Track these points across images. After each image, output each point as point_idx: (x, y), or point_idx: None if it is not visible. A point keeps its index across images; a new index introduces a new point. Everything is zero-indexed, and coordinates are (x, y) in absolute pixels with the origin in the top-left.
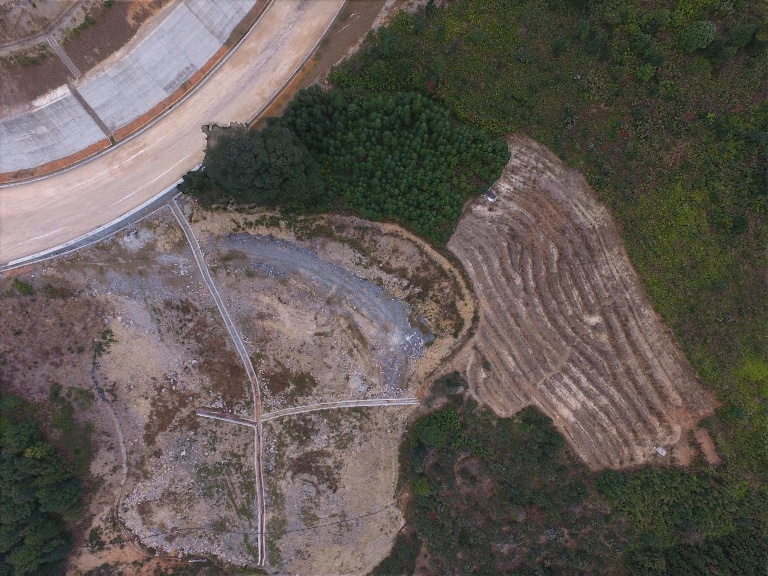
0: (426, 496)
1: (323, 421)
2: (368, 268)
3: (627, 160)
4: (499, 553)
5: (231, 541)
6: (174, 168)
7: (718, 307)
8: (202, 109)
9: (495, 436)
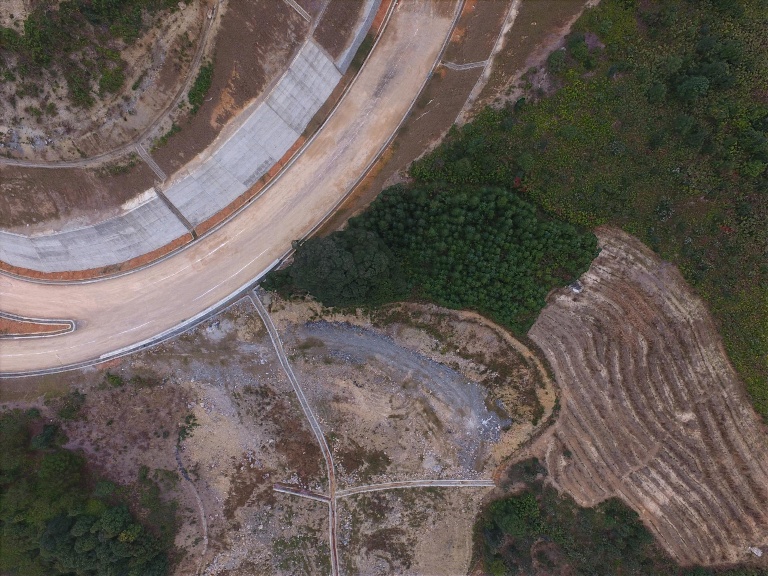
0: None
1: (397, 500)
2: (445, 353)
3: (728, 254)
4: None
5: None
6: (254, 261)
7: None
8: (280, 201)
9: (576, 525)
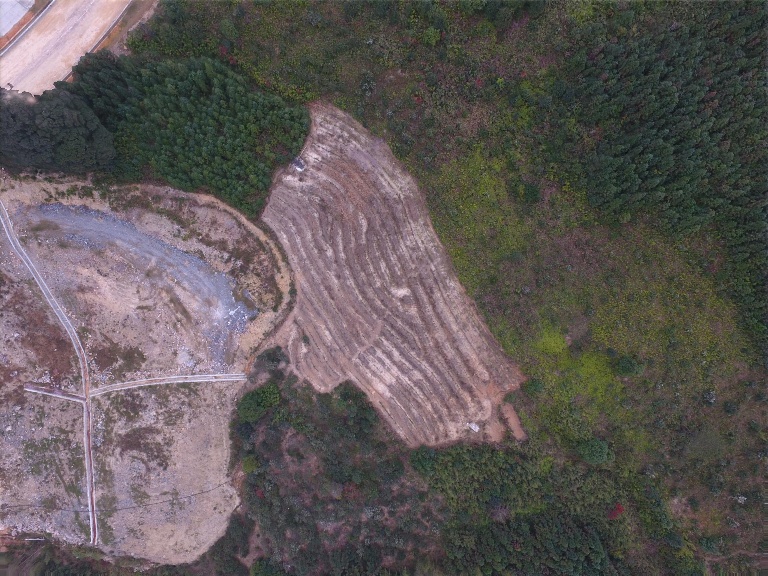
0: (255, 474)
1: (151, 397)
2: (187, 240)
3: (427, 128)
4: (323, 532)
5: (63, 519)
6: None
7: (517, 278)
8: (6, 76)
9: (314, 412)
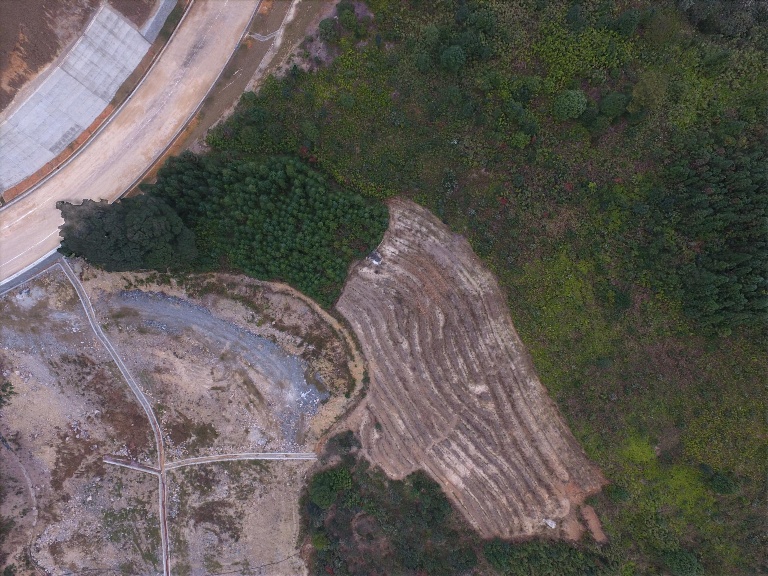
0: (324, 550)
1: (223, 472)
2: (261, 325)
3: (510, 227)
4: None
5: None
6: None
7: (603, 383)
8: (89, 169)
9: (386, 498)
